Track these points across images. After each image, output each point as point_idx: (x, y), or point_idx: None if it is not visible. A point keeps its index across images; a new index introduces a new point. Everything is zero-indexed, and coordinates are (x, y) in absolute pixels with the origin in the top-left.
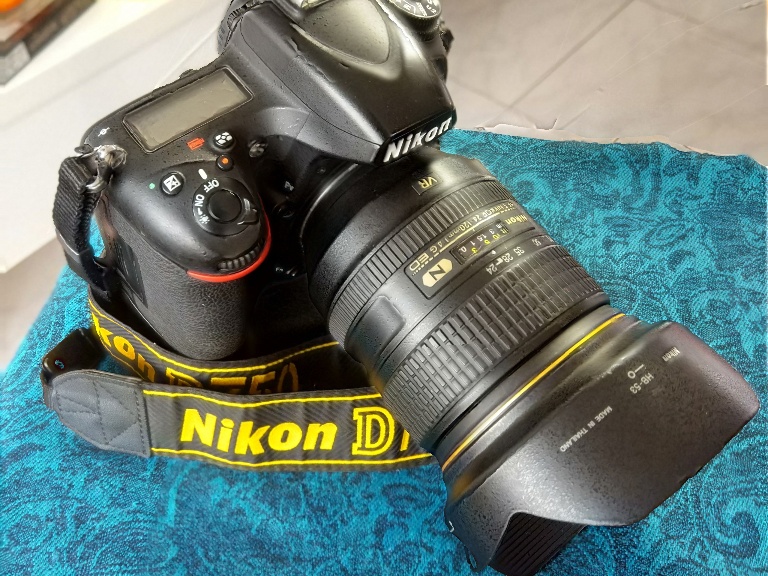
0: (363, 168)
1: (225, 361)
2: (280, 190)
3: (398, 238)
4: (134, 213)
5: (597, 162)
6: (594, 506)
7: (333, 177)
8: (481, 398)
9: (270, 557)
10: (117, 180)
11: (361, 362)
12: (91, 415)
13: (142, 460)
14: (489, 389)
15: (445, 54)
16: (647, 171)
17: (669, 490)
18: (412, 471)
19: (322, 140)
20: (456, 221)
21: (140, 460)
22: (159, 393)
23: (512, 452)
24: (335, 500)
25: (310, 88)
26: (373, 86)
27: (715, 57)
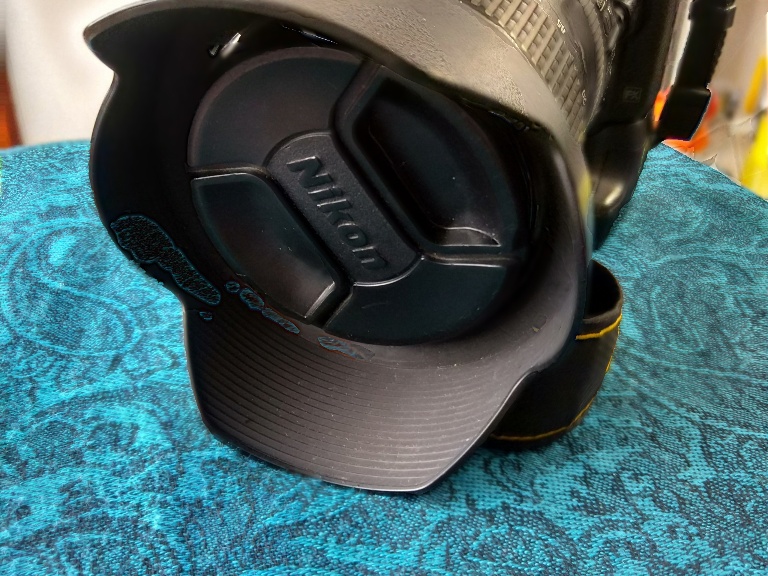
0: None
1: None
2: None
3: None
4: None
5: None
6: None
7: None
8: None
9: (141, 260)
10: None
11: None
12: None
13: None
14: None
15: None
16: None
17: None
18: None
19: None
20: None
21: None
22: None
23: None
24: None
25: None
26: None
27: None
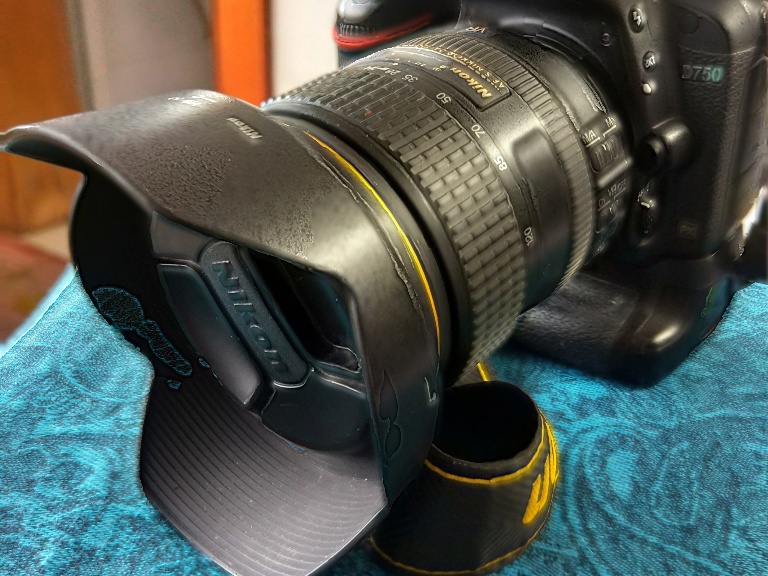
0: None
1: None
2: None
3: None
4: None
5: None
6: None
7: None
8: None
9: None
10: None
11: None
12: None
13: None
14: None
15: (731, 29)
16: None
17: None
18: None
19: None
20: None
21: None
22: None
23: None
24: None
25: None
26: None
27: None
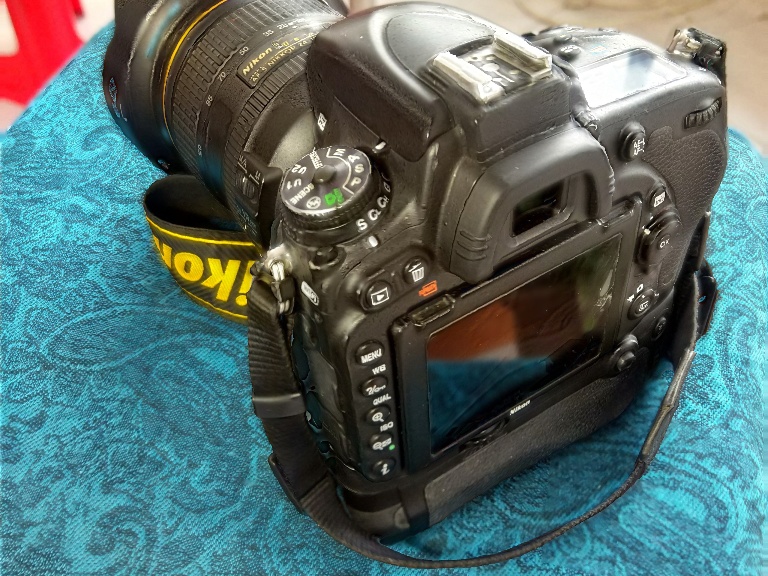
0: None
1: None
2: None
3: None
4: None
5: None
6: None
7: None
8: None
9: None
10: None
11: None
12: None
13: None
14: None
15: None
16: None
17: None
18: None
19: None
20: None
21: None
22: None
23: None
24: None
25: None
26: None
27: None
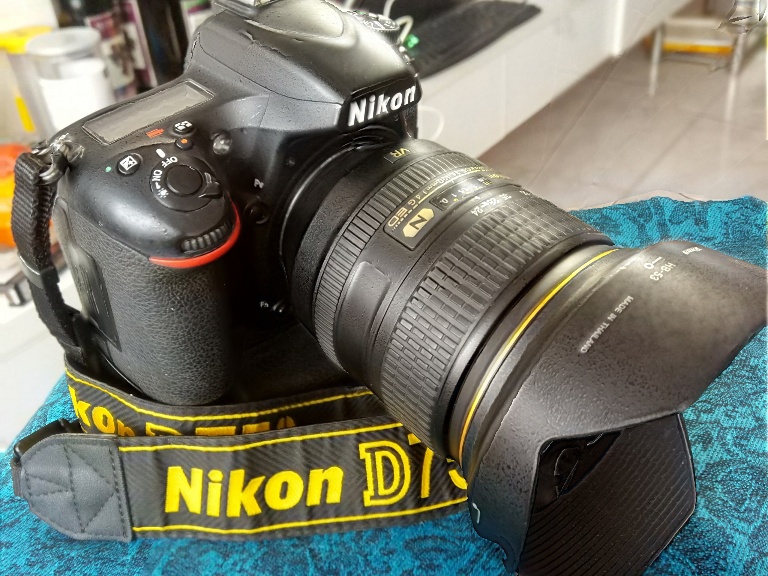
0: (335, 161)
1: (210, 406)
2: (250, 190)
3: (373, 201)
4: (91, 203)
5: (599, 223)
6: (633, 401)
7: (305, 174)
8: (485, 341)
9: None
10: (74, 174)
11: (354, 360)
12: (64, 494)
13: (122, 545)
14: (493, 328)
15: None
16: (652, 223)
17: (720, 362)
18: (438, 522)
19: (284, 119)
20: (433, 178)
21: (120, 545)
22: (136, 448)
23: (527, 375)
24: (349, 561)
25: (267, 68)
26: (328, 53)
27: (698, 128)
